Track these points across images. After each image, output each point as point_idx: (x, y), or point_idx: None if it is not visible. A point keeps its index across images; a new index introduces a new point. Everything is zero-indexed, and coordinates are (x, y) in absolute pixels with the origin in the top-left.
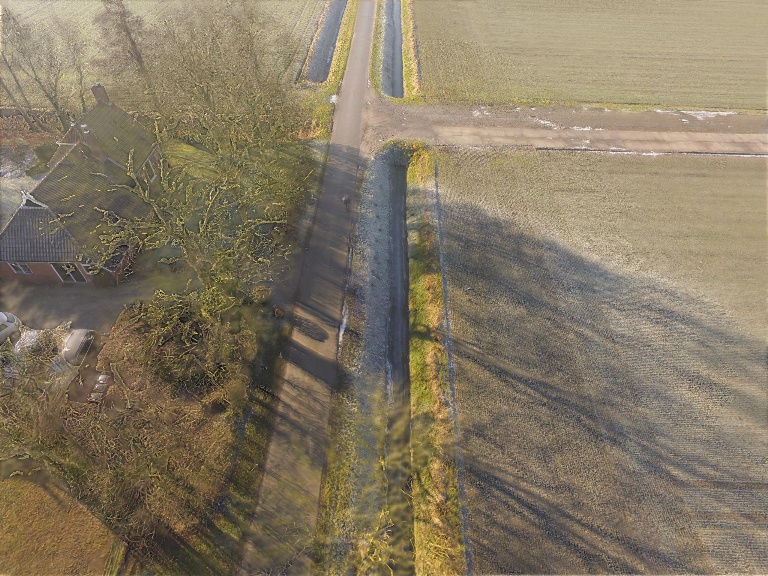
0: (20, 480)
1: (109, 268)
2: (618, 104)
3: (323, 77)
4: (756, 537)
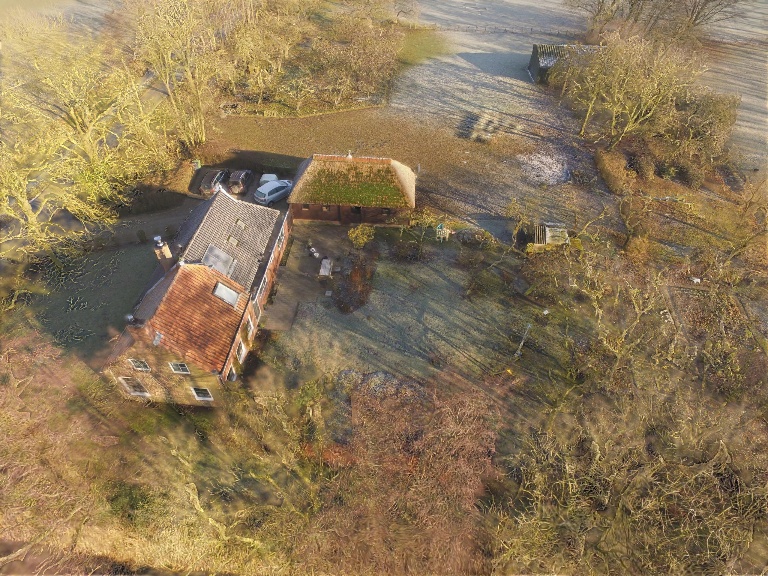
0: None
1: None
2: None
3: None
4: None
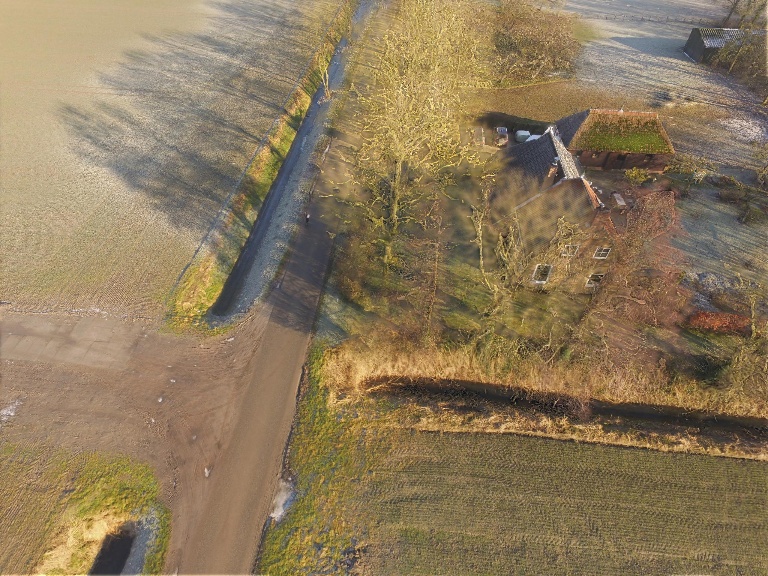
0: None
1: None
2: None
3: None
4: (179, 89)
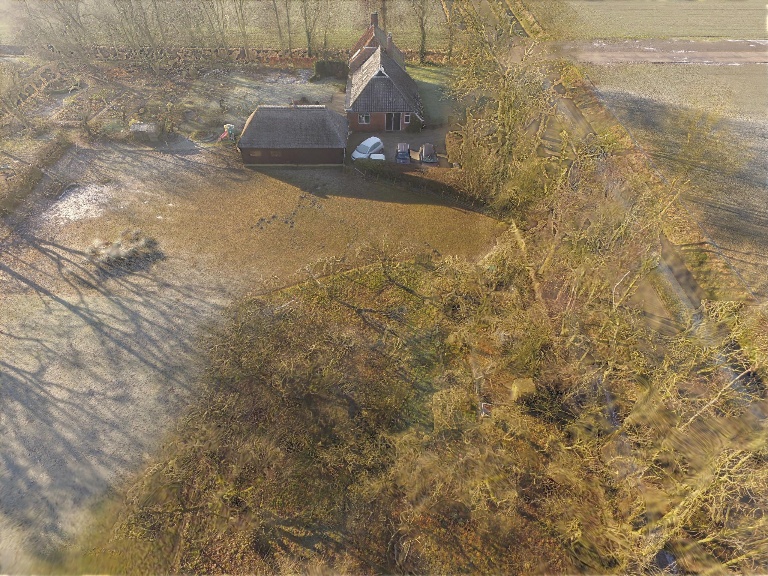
0: (436, 205)
1: (421, 117)
2: (699, 37)
3: (462, 29)
4: None
